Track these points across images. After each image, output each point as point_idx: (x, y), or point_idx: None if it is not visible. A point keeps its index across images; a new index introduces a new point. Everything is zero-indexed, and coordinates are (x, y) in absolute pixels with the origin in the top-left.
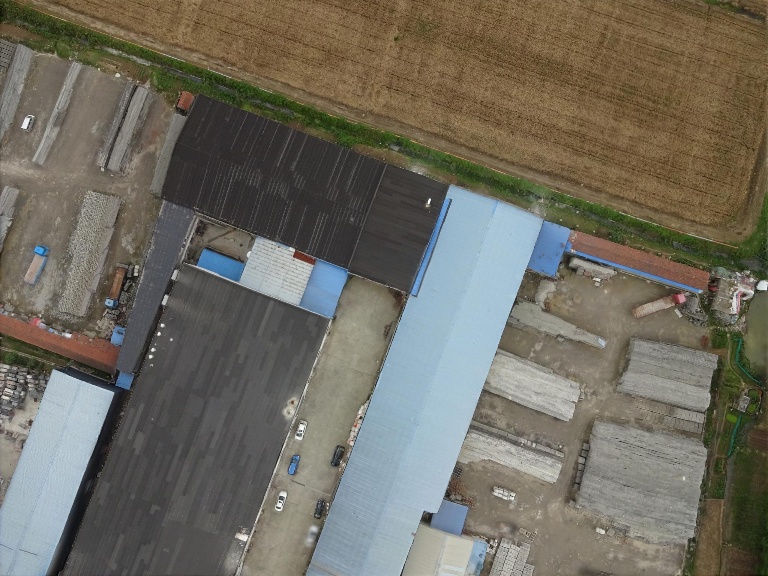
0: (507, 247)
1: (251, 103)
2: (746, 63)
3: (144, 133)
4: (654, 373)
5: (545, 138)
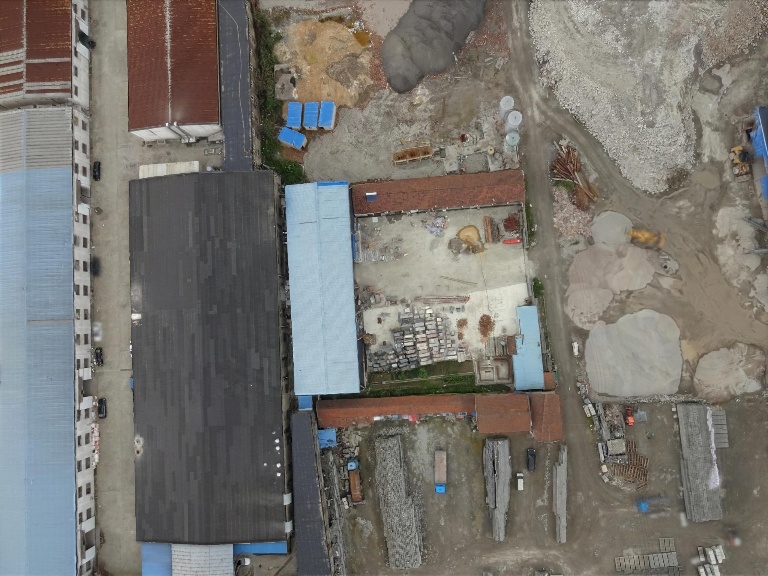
0: None
1: None
2: None
3: None
4: None
5: None
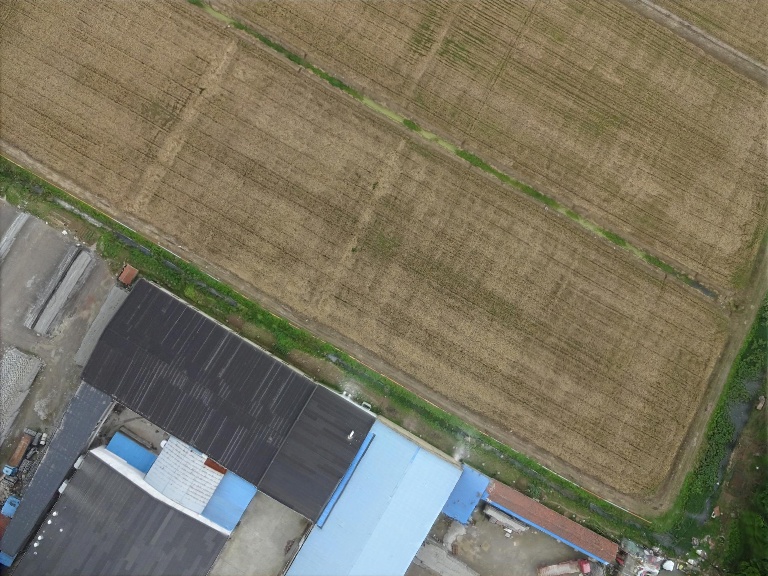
0: (421, 494)
1: (196, 287)
2: (691, 339)
3: (80, 297)
4: None
5: (483, 378)
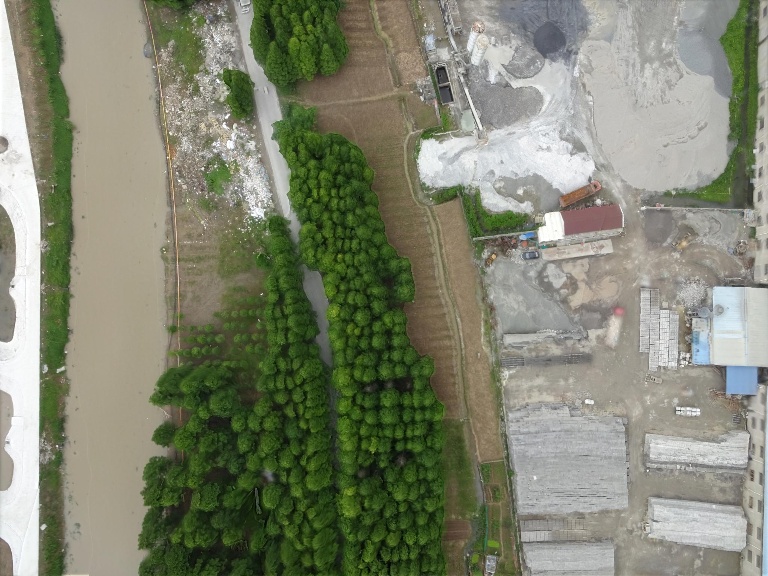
0: None
1: None
2: None
3: None
4: (589, 573)
5: None
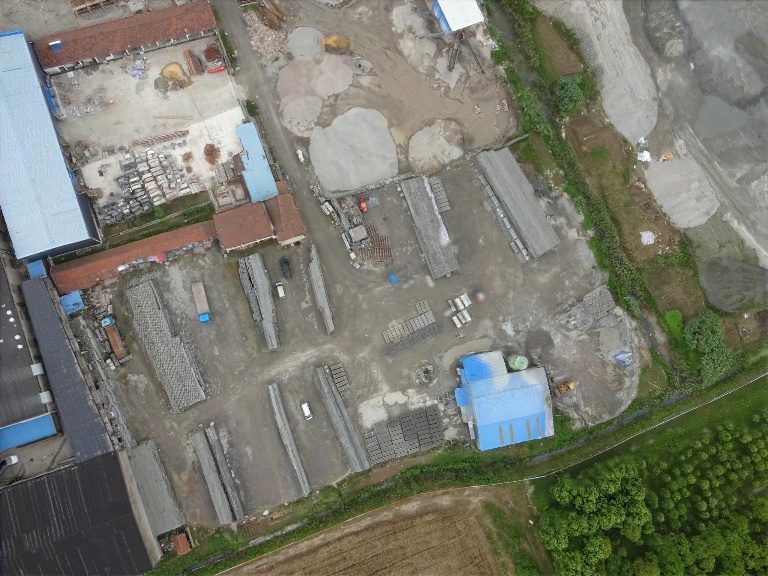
0: None
1: None
2: None
3: (202, 483)
4: None
5: None
